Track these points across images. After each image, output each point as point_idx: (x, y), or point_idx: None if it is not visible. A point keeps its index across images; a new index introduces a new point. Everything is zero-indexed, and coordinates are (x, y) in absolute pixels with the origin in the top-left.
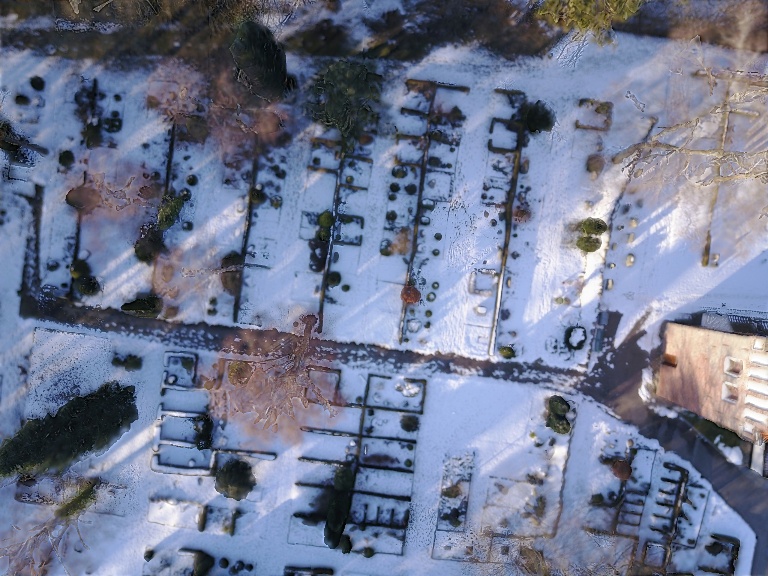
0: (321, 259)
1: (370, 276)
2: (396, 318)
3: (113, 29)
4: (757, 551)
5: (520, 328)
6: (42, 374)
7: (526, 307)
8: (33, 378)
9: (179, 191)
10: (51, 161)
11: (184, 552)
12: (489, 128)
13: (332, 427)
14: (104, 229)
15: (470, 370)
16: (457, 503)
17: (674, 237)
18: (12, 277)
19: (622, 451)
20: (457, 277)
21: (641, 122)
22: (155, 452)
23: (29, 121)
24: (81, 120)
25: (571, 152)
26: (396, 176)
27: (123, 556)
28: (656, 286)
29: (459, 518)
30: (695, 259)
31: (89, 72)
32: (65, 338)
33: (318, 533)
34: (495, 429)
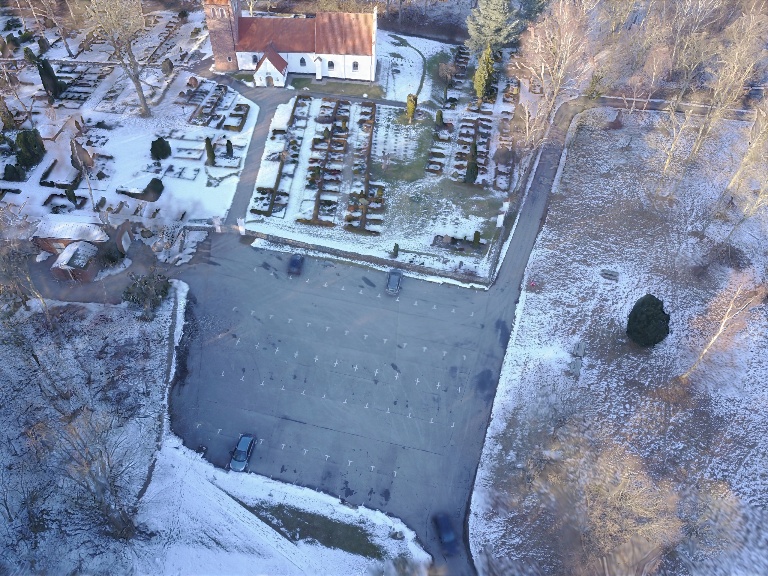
0: None
1: None
2: None
3: None
4: (260, 112)
5: None
6: None
7: None
8: None
9: None
10: None
11: None
12: (167, 24)
13: None
14: None
15: None
16: None
17: None
18: None
19: None
20: None
21: None
22: None
23: None
24: None
25: None
26: None
27: None
28: None
29: None
30: None
31: None
32: None
33: None
34: None
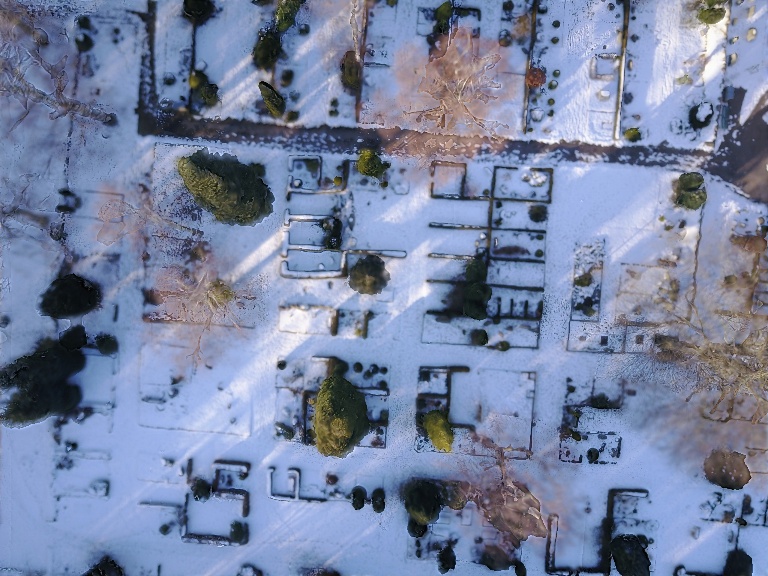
0: (441, 52)
1: None
2: (519, 109)
3: None
4: None
5: (644, 111)
6: (165, 189)
7: (649, 90)
8: (156, 194)
9: None
10: None
11: (318, 358)
12: None
13: (460, 222)
14: (220, 39)
15: (596, 157)
16: (590, 291)
17: None
18: (129, 95)
19: (753, 230)
20: (577, 64)
21: None
22: (284, 258)
23: None
24: None
25: None
26: None
27: (255, 369)
28: None
29: (593, 307)
30: None
31: None
32: (186, 151)
33: (452, 330)
34: (624, 215)
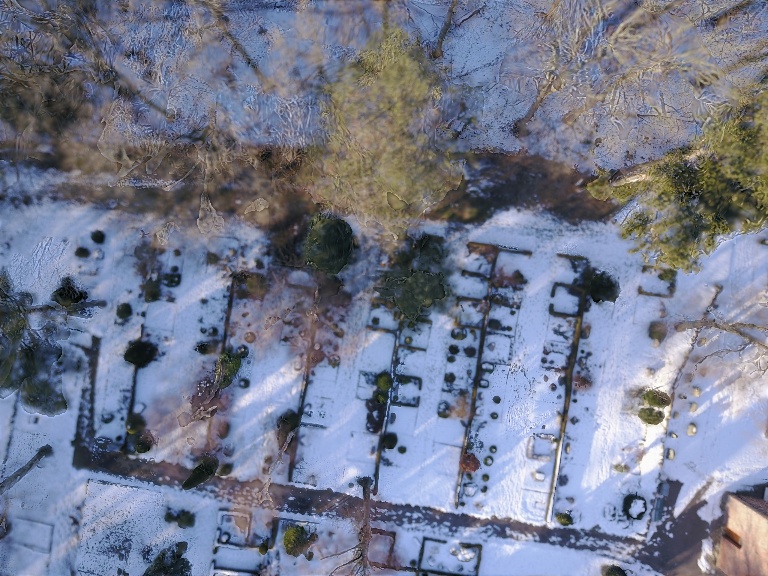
0: (378, 421)
1: (427, 438)
2: (452, 481)
3: (175, 186)
4: None
5: (578, 494)
6: (94, 526)
7: (584, 473)
8: (85, 530)
9: (236, 348)
10: (108, 313)
11: None
12: (550, 292)
13: None
14: (160, 383)
15: (526, 535)
16: None
17: (737, 407)
18: (66, 427)
19: None
20: (515, 441)
21: (705, 290)
22: None
23: (88, 273)
24: (140, 273)
25: (633, 318)
26: (455, 338)
27: None
28: (718, 456)
29: None
30: (758, 430)
31: (149, 226)
32: (118, 491)
33: None
34: None
